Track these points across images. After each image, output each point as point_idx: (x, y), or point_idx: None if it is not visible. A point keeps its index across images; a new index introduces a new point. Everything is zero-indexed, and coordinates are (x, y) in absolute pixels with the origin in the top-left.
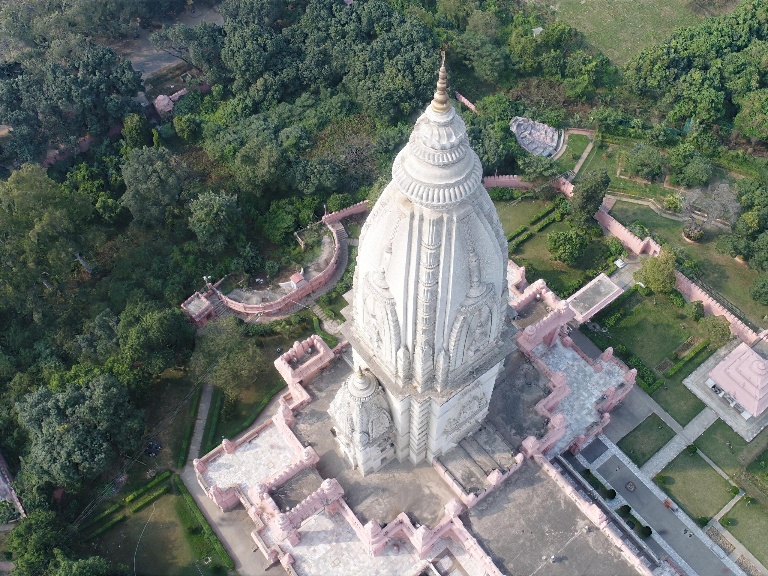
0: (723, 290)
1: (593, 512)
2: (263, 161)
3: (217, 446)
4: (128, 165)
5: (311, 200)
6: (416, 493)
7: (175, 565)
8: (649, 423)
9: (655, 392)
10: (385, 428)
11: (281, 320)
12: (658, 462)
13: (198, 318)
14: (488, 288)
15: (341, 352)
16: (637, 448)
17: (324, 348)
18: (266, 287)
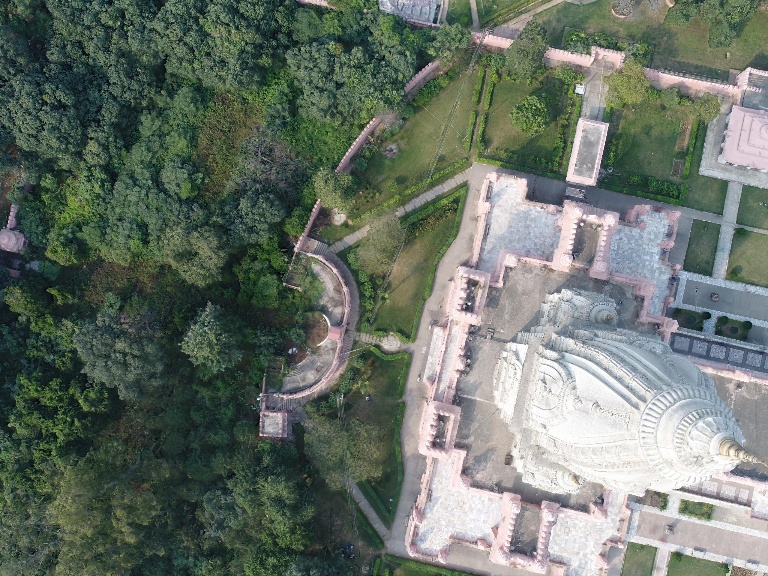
0: (680, 52)
1: (742, 379)
2: (204, 252)
3: (411, 526)
4: (89, 365)
5: (270, 242)
6: None
7: None
8: (696, 232)
9: (684, 200)
10: None
11: (348, 375)
12: (722, 261)
13: (284, 434)
14: None
15: (456, 394)
16: (700, 261)
17: (454, 415)
18: (305, 353)
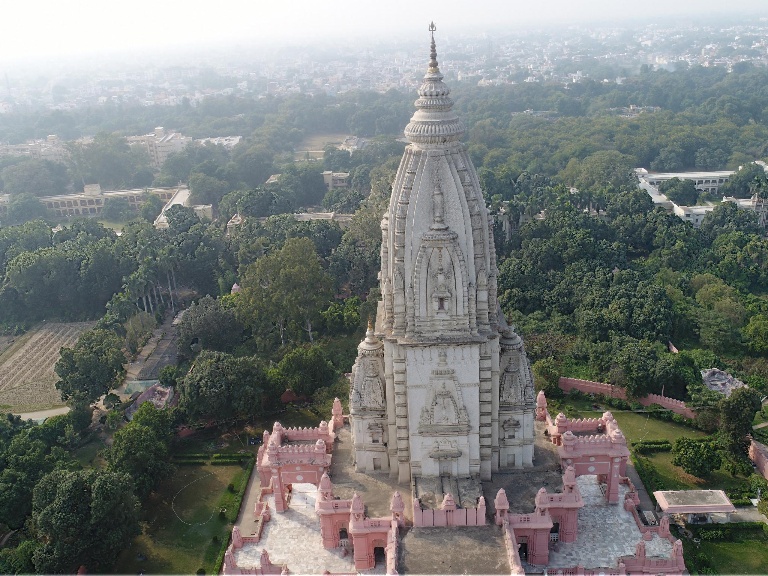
0: None
1: (515, 569)
2: None
3: None
4: None
5: None
6: (382, 498)
7: (203, 502)
8: None
9: None
10: (377, 402)
11: None
12: None
13: None
14: (450, 232)
15: None
16: None
17: None
18: None
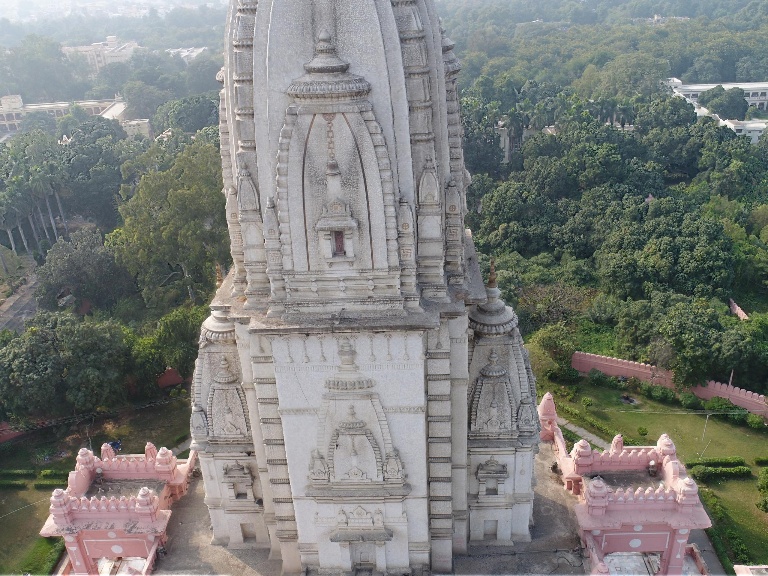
0: None
1: None
2: None
3: None
4: None
5: None
6: None
7: None
8: None
9: None
10: (238, 430)
11: None
12: None
13: None
14: (350, 77)
15: None
16: None
17: None
18: None
